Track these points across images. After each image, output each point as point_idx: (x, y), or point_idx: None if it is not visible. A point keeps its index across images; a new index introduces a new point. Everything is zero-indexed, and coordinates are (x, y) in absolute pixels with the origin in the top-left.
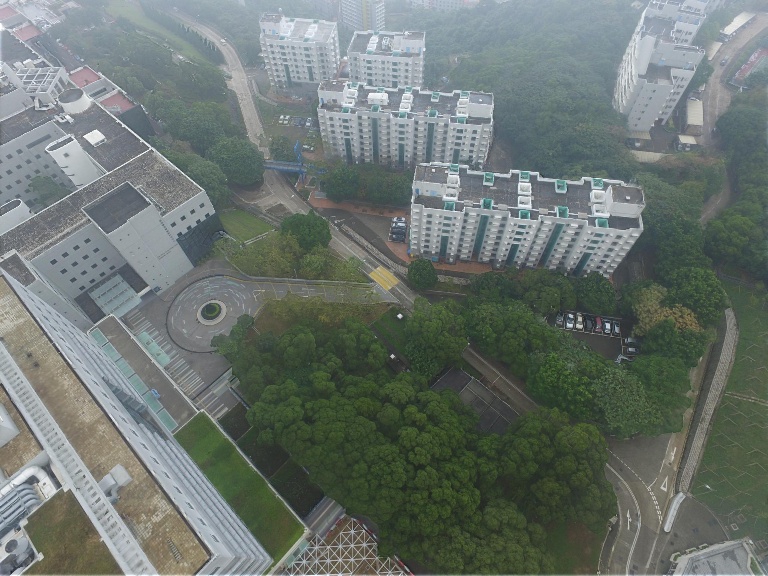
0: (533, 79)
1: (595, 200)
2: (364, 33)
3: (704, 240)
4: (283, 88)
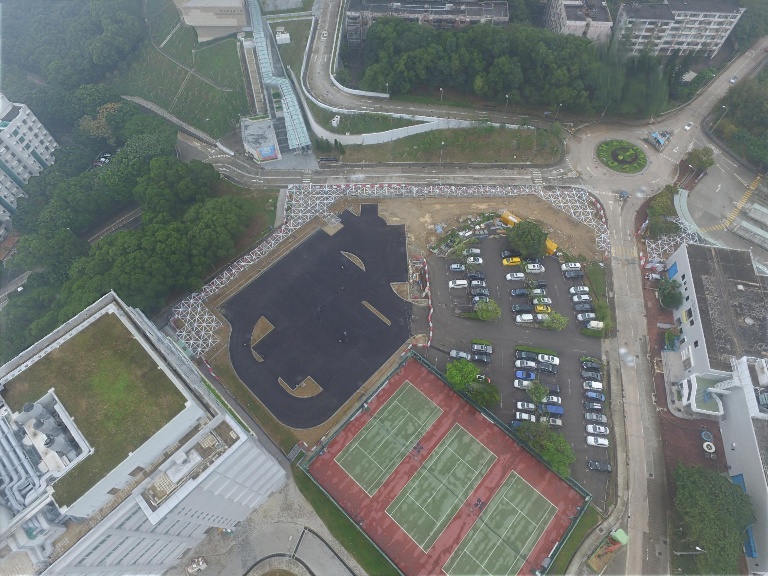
0: None
1: None
2: None
3: (59, 88)
4: None
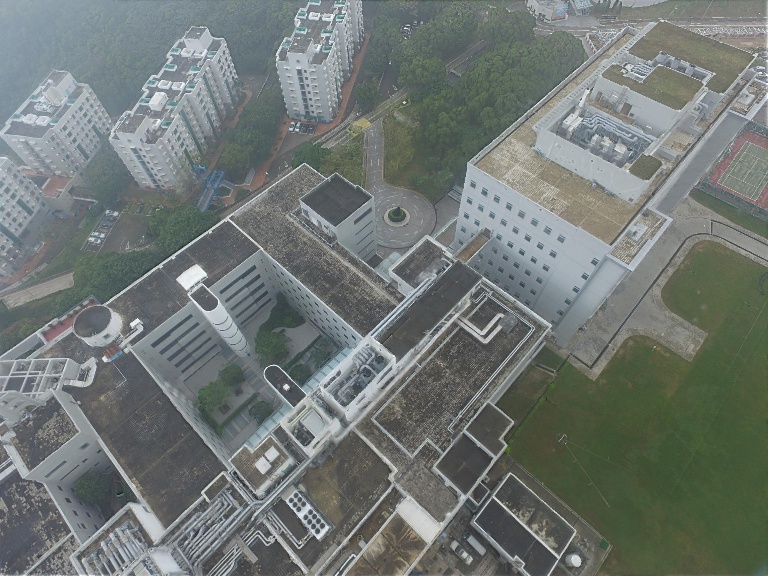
0: (153, 28)
1: None
2: (7, 128)
3: None
4: (17, 255)
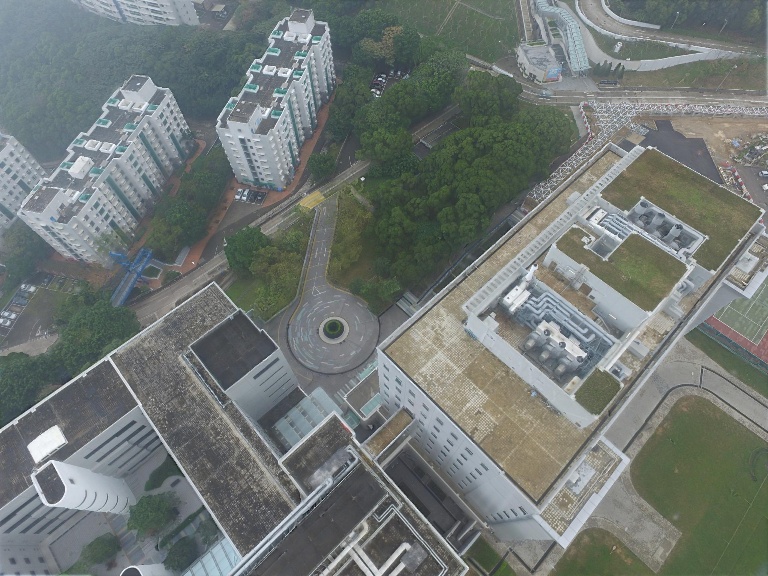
0: (101, 66)
1: (293, 38)
2: None
3: None
4: None
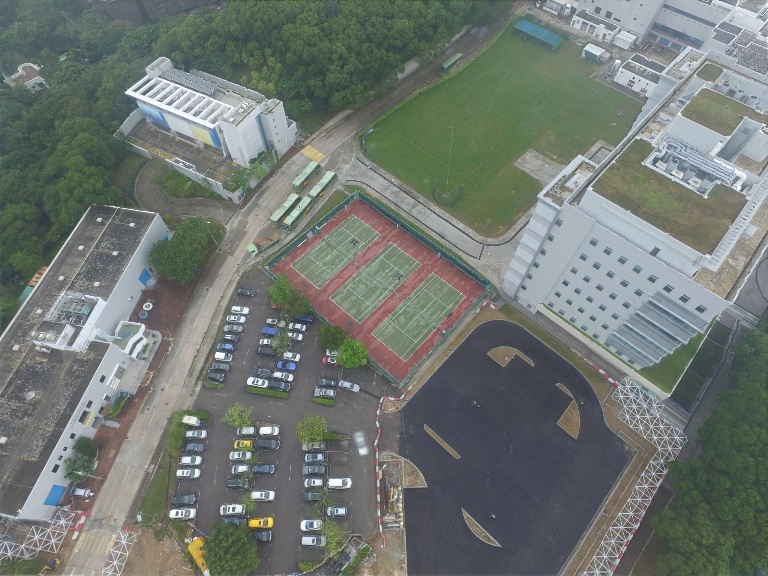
0: None
1: None
2: None
3: None
4: None
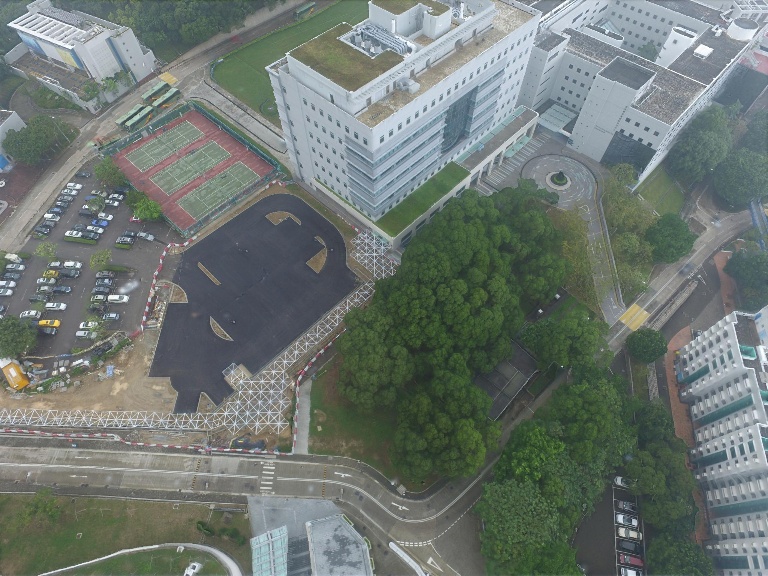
0: None
1: None
2: None
3: None
4: None
